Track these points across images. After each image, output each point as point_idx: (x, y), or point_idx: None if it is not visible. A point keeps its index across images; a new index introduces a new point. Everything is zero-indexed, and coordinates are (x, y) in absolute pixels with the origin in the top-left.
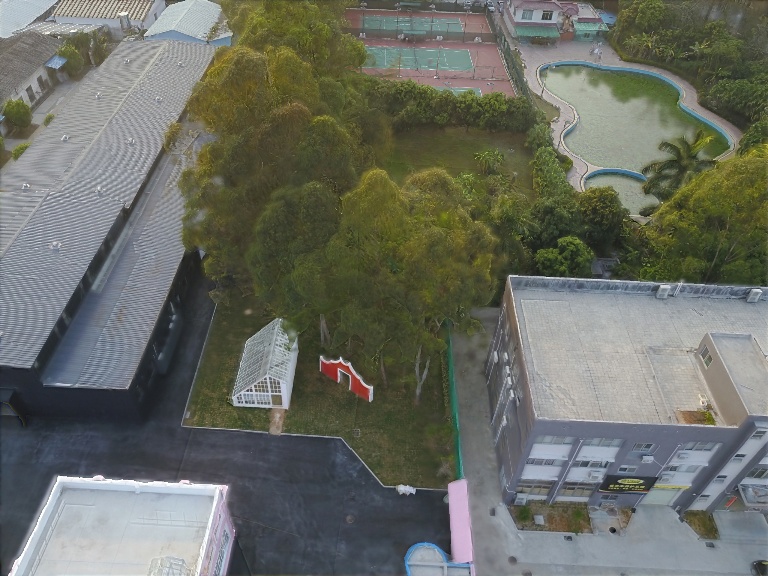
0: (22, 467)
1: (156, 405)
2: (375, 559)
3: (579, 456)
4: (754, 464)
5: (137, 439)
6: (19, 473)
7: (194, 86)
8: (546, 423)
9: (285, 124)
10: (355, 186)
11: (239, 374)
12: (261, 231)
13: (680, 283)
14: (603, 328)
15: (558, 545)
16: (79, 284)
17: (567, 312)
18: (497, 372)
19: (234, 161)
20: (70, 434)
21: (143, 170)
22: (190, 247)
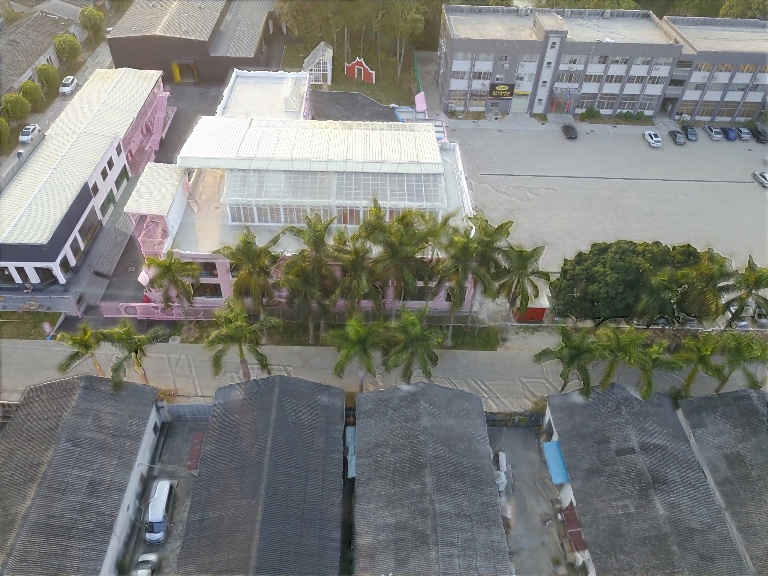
0: (202, 96)
1: None
2: None
3: (475, 69)
4: (556, 69)
5: None
6: (201, 97)
7: None
8: (457, 41)
9: None
10: None
11: (303, 69)
12: None
13: (530, 7)
14: (489, 23)
15: (469, 123)
16: (217, 20)
17: (472, 19)
18: None
19: None
20: (221, 87)
21: None
22: None
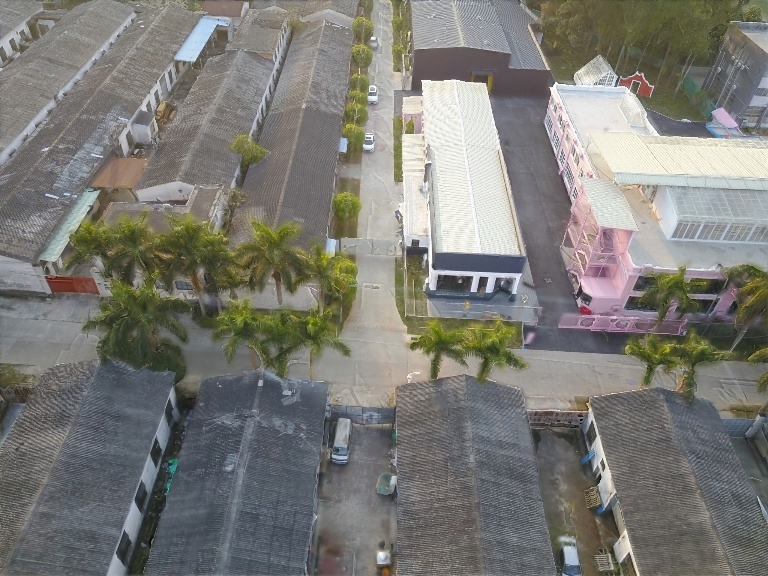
0: (501, 107)
1: (545, 93)
2: None
3: None
4: None
5: (546, 102)
6: (501, 109)
7: None
8: None
9: None
10: None
11: (582, 82)
12: None
13: None
14: None
15: None
16: None
17: (763, 36)
18: (719, 78)
19: None
20: (513, 99)
21: None
22: (577, 2)
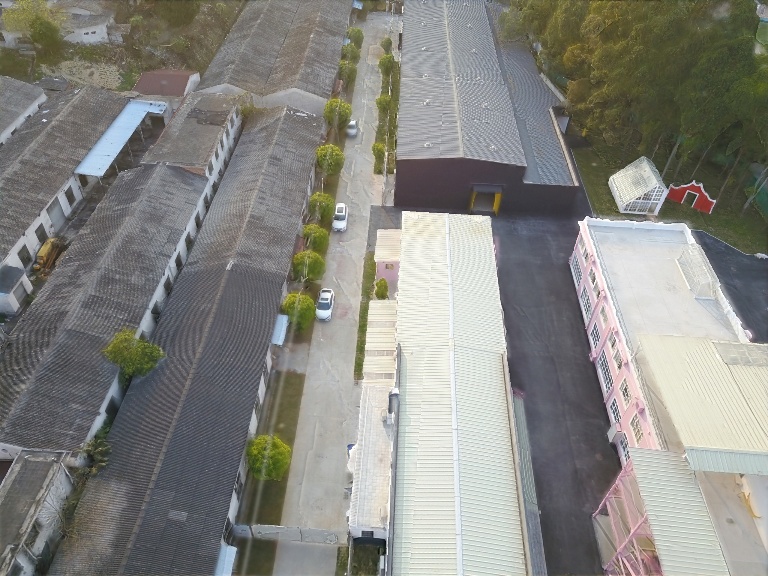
0: (511, 235)
1: (571, 209)
2: (762, 287)
3: None
4: None
5: (572, 225)
6: (511, 238)
7: (501, 16)
8: None
9: (722, 1)
10: (757, 44)
11: (620, 193)
12: (705, 69)
13: None
14: None
15: None
16: None
17: None
18: None
19: (668, 30)
20: (528, 221)
21: (496, 69)
22: (616, 94)
